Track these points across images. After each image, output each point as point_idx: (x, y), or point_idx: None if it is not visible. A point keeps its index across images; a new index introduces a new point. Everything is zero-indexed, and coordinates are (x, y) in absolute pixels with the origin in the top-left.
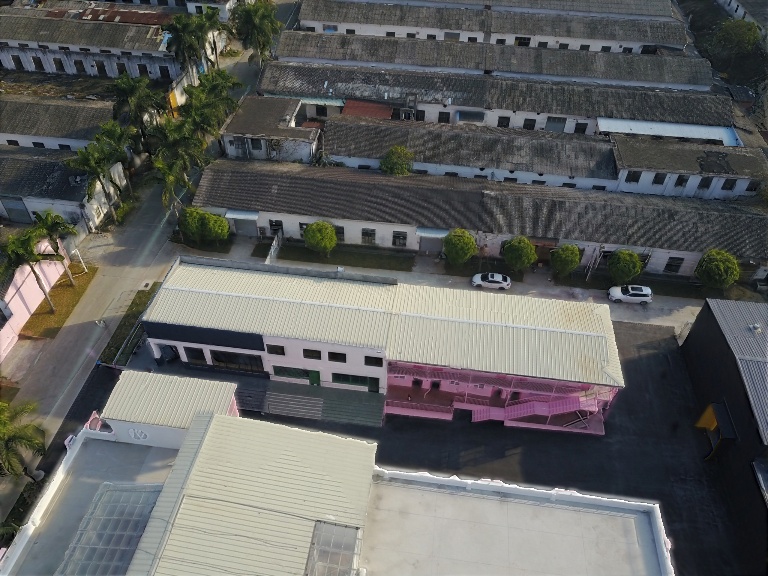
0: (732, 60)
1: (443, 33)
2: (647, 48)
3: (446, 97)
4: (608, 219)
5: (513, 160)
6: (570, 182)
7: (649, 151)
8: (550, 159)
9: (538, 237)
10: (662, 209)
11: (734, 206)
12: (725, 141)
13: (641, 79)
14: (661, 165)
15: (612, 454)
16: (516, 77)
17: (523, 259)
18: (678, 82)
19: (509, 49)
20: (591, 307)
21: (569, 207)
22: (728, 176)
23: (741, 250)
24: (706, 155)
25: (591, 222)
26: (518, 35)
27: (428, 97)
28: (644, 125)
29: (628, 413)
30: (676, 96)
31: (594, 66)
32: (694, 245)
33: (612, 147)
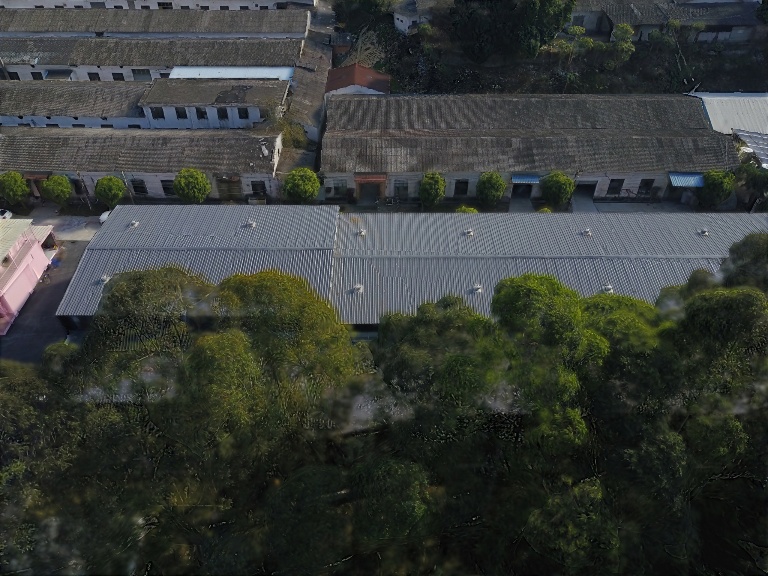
0: (345, 10)
1: (89, 3)
2: (280, 5)
3: (34, 57)
4: (104, 150)
5: (50, 107)
6: (106, 123)
7: (179, 89)
8: (86, 103)
9: (32, 171)
10: (158, 138)
11: (239, 131)
12: (281, 79)
13: (240, 31)
14: (180, 100)
15: (1, 350)
16: (122, 37)
17: (6, 191)
18: (273, 31)
19: (123, 11)
20: (11, 222)
21: (71, 142)
22: (236, 105)
23: (217, 167)
24: (231, 89)
25: (87, 154)
26: (159, 1)
27: (16, 59)
28: (214, 70)
29: (42, 315)
30: (252, 42)
31: (199, 22)
32: (175, 167)
33: (147, 88)
